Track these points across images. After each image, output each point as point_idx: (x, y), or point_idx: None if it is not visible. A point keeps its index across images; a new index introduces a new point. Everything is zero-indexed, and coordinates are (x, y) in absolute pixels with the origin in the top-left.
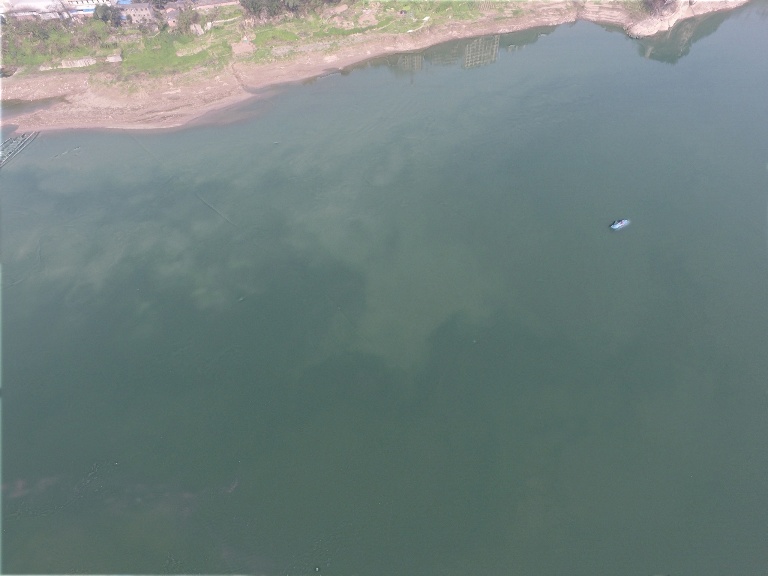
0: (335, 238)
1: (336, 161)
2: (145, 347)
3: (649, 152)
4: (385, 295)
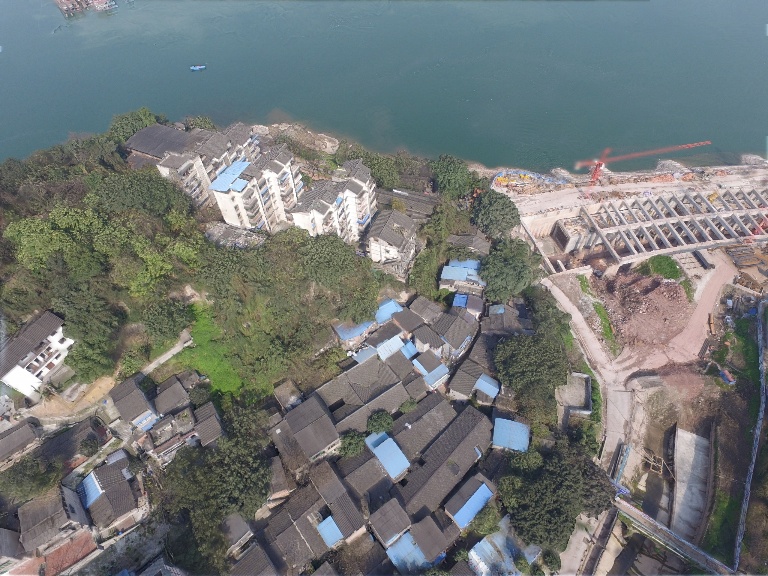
0: None
1: None
2: (476, 24)
3: None
4: (583, 12)
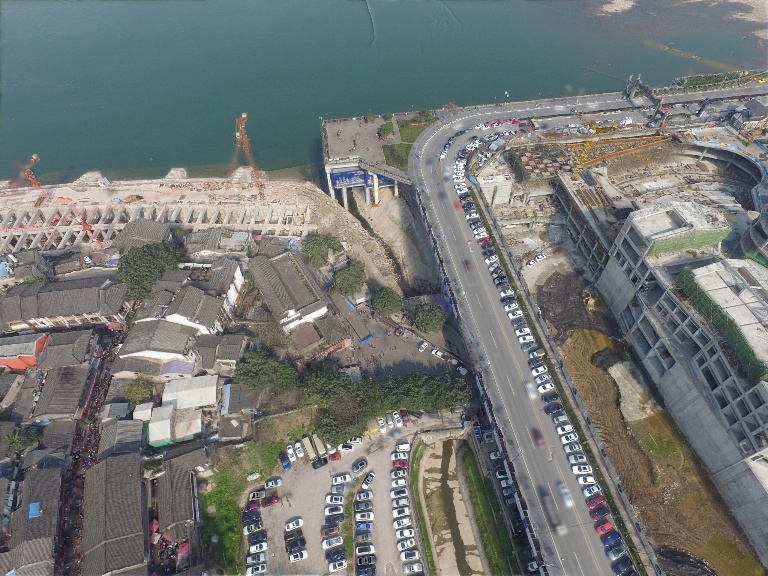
0: (127, 7)
1: None
2: None
3: None
4: None
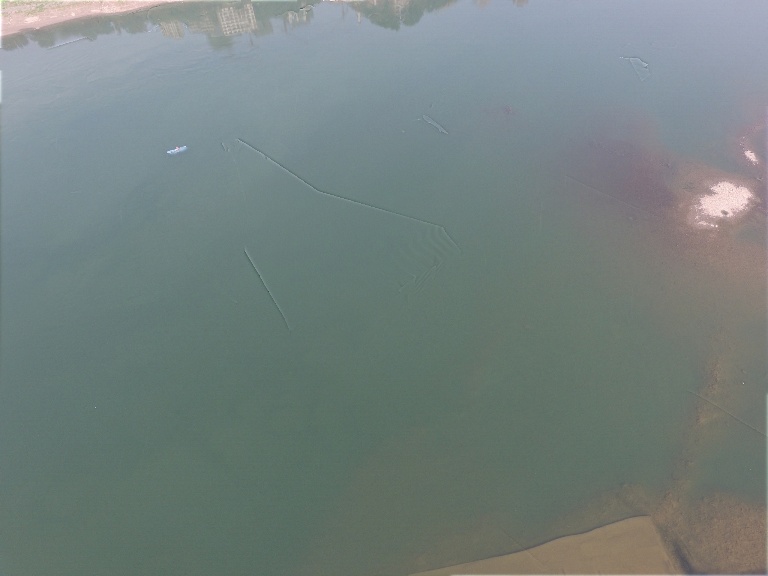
0: None
1: None
2: None
3: (269, 96)
4: None
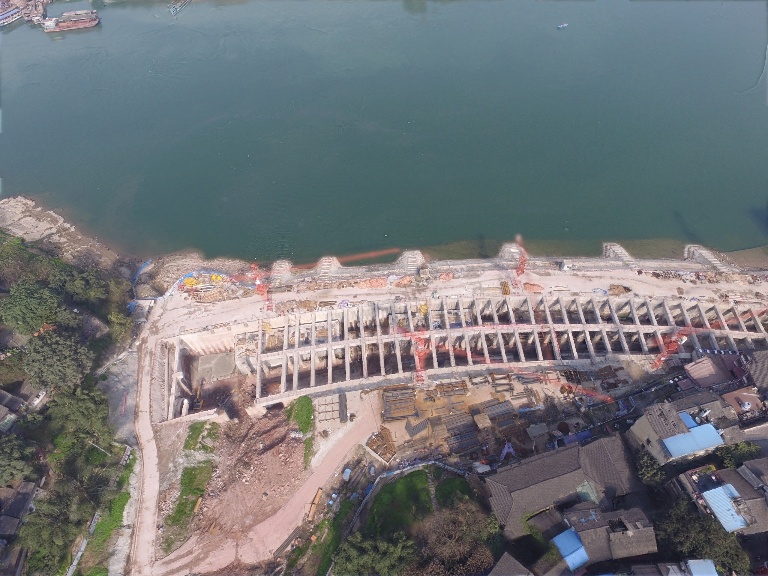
0: (395, 38)
1: (390, 7)
2: (300, 72)
3: (588, 3)
4: (428, 55)
